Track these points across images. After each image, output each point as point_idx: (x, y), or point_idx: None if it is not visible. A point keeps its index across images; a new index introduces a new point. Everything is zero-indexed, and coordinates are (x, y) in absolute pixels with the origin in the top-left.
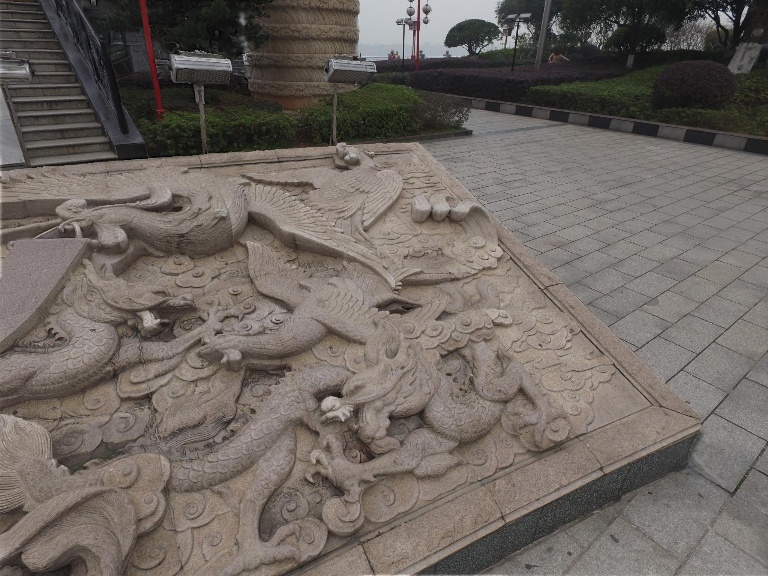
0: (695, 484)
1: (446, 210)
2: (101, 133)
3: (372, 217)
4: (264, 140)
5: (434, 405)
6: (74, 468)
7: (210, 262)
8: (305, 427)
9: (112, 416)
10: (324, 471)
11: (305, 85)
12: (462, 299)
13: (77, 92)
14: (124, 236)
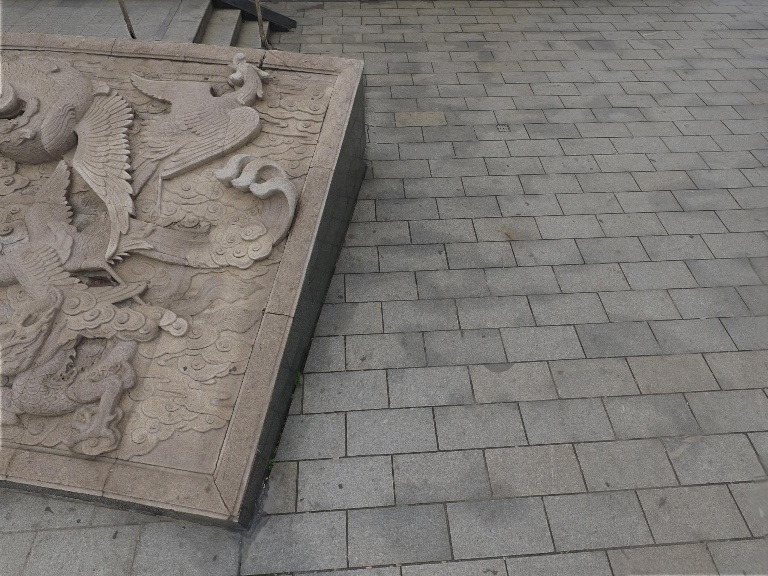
0: (224, 548)
1: (241, 185)
2: None
3: (178, 167)
4: None
5: (19, 378)
6: None
7: (31, 171)
8: None
9: None
10: None
11: None
12: (175, 290)
13: None
14: None
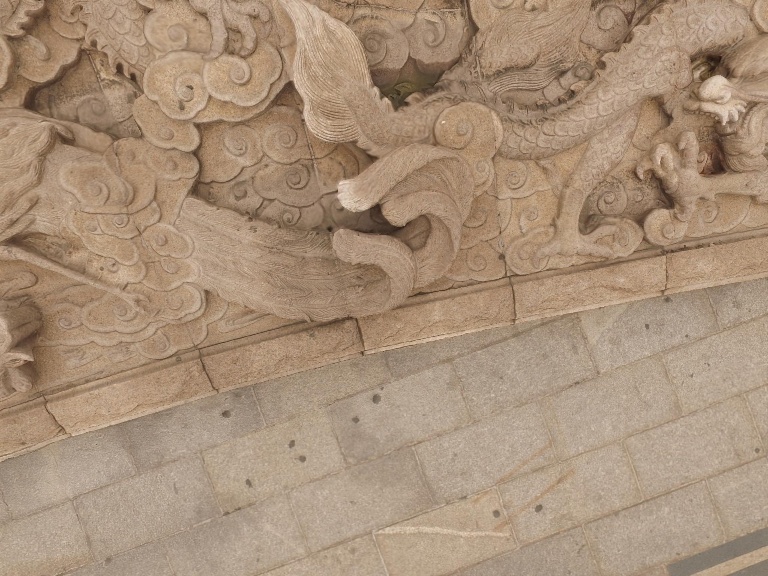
0: None
1: None
2: None
3: None
4: None
5: None
6: (385, 90)
7: None
8: (656, 103)
9: (416, 15)
10: (662, 173)
11: None
12: None
13: None
14: None
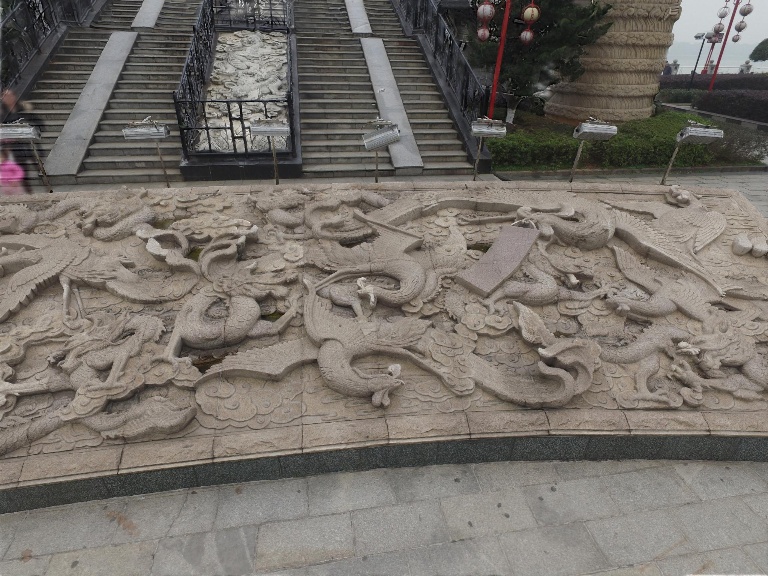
0: None
1: (766, 250)
2: (461, 148)
3: (702, 245)
4: (561, 159)
5: (751, 364)
6: None
7: (590, 254)
8: (664, 354)
9: (558, 321)
10: (679, 375)
11: (601, 111)
12: None
13: (445, 116)
14: (553, 232)
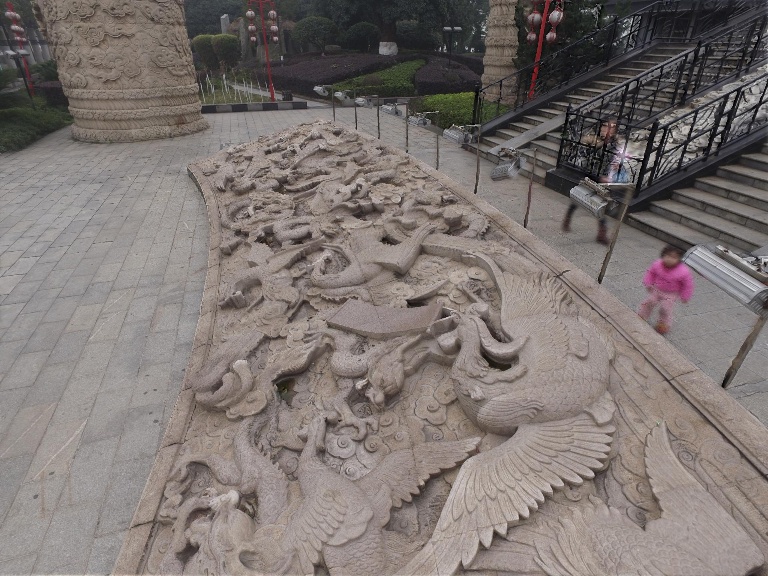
0: None
1: None
2: None
3: None
4: None
5: None
6: (286, 386)
7: (456, 416)
8: None
9: None
10: None
11: None
12: None
13: None
14: (447, 344)
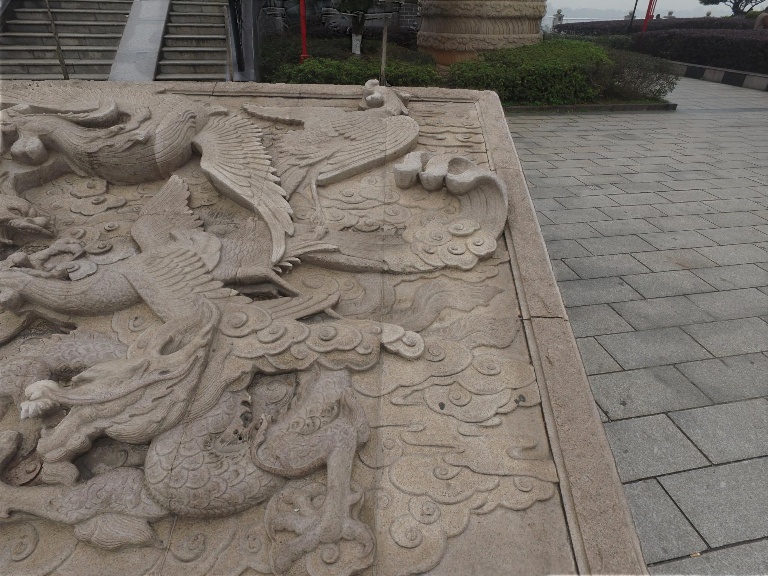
0: None
1: (436, 175)
2: None
3: (337, 170)
4: None
5: (162, 441)
6: None
7: (127, 192)
8: None
9: None
10: None
11: (470, 38)
12: (378, 302)
13: None
14: (34, 146)
